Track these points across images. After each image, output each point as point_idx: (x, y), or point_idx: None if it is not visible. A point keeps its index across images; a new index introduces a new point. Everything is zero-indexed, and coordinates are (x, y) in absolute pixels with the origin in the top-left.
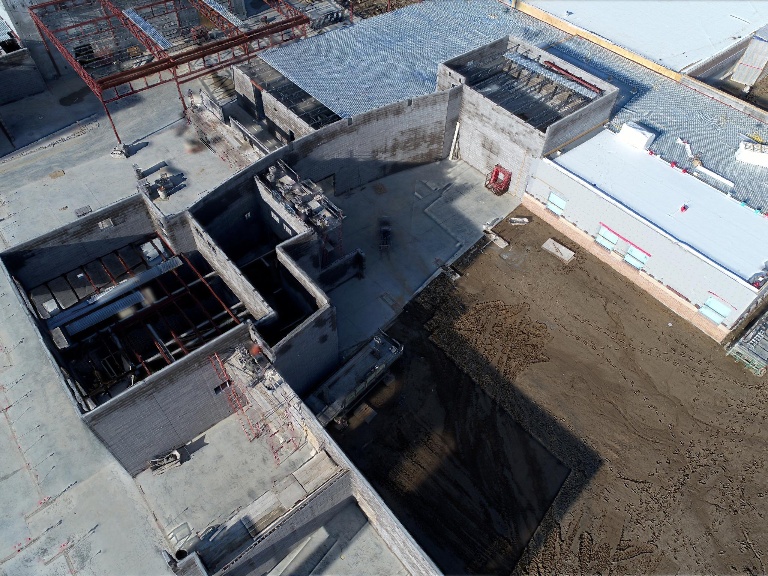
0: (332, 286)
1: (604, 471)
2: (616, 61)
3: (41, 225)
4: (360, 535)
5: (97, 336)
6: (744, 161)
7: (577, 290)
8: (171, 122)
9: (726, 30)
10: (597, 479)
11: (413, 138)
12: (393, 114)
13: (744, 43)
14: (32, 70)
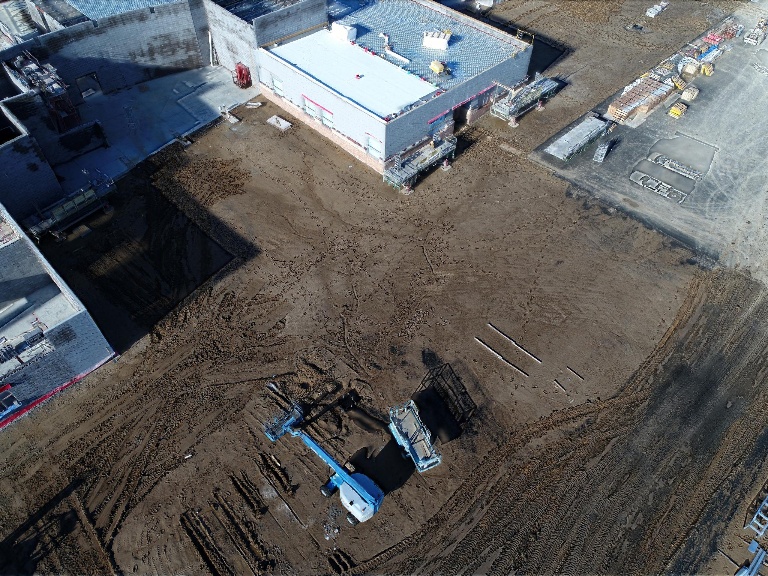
0: (79, 152)
1: (261, 257)
2: None
3: None
4: (52, 300)
5: None
6: (427, 46)
7: (285, 148)
8: None
9: None
10: (253, 262)
11: (168, 44)
12: (139, 20)
13: None
14: None
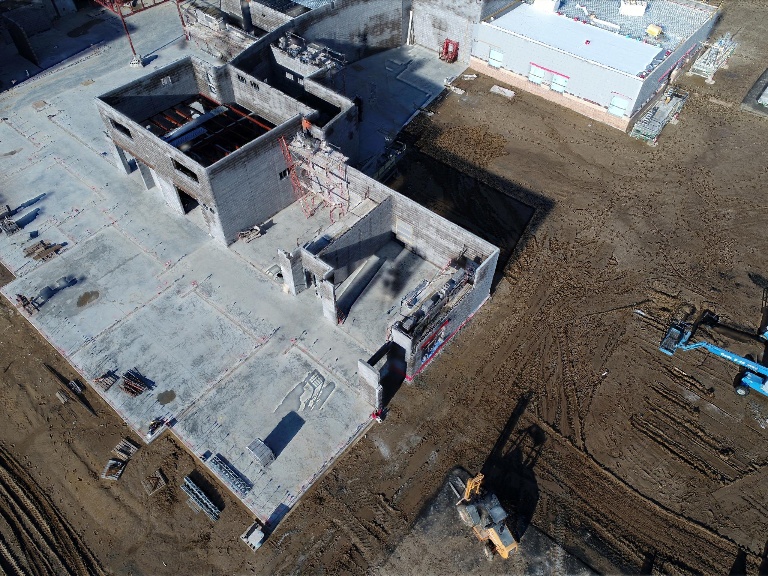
0: None
1: (558, 207)
2: None
3: (89, 115)
4: (401, 255)
5: None
6: (625, 14)
7: (521, 113)
8: (171, 40)
9: None
10: (555, 211)
11: (379, 24)
12: (363, 1)
13: None
14: (40, 9)
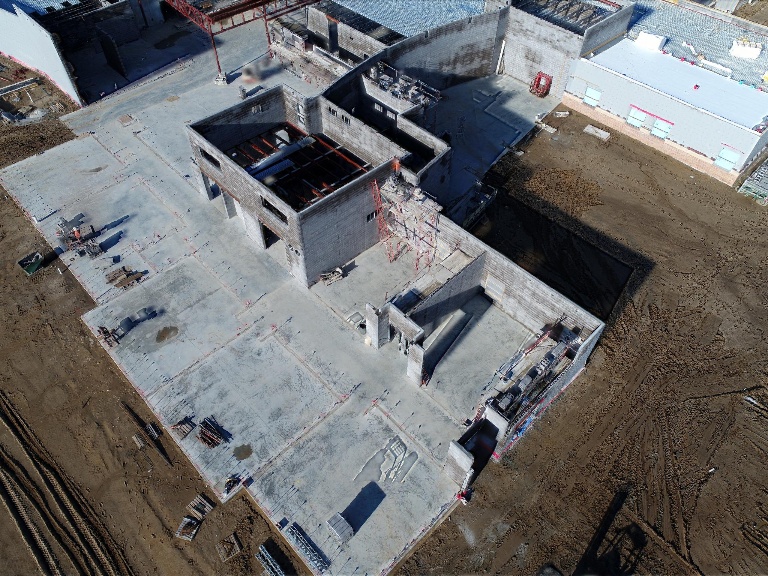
0: None
1: (658, 268)
2: None
3: (174, 134)
4: (489, 312)
5: None
6: (737, 56)
7: (617, 158)
8: (256, 57)
9: None
10: (654, 273)
11: (470, 53)
12: (457, 30)
13: None
14: (130, 19)
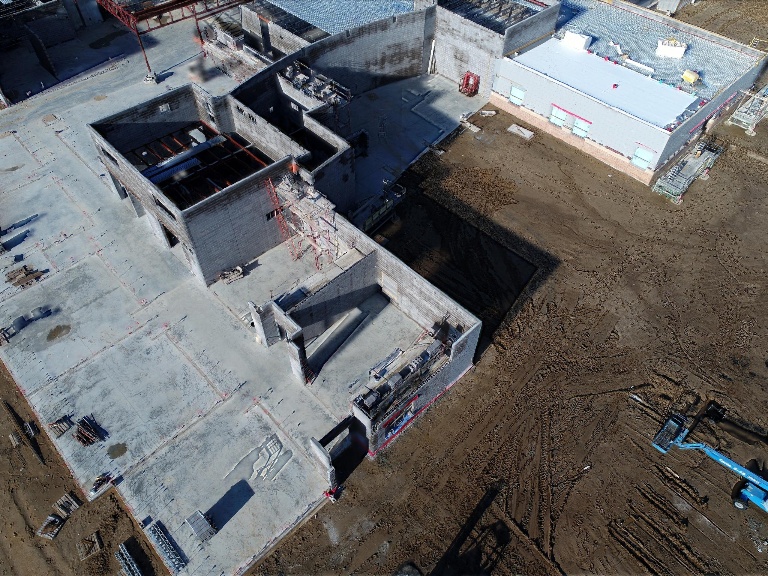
0: None
1: (563, 267)
2: None
3: None
4: (385, 310)
5: (169, 187)
6: (662, 55)
7: (537, 157)
8: (190, 57)
9: None
10: (558, 272)
11: (398, 53)
12: (381, 29)
13: None
14: (64, 19)
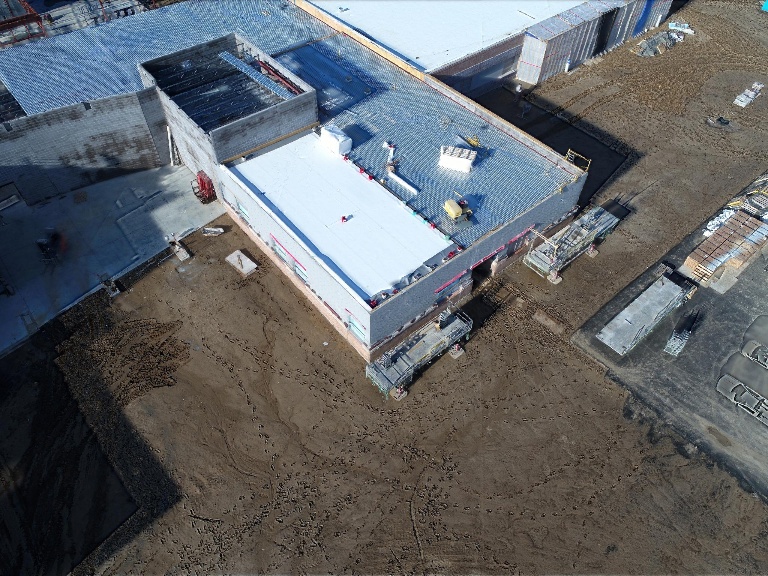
0: None
1: (176, 508)
2: (369, 60)
3: None
4: None
5: None
6: (445, 166)
7: (242, 306)
8: None
9: (505, 26)
10: (164, 518)
11: (112, 143)
12: (70, 118)
13: (515, 40)
14: None
